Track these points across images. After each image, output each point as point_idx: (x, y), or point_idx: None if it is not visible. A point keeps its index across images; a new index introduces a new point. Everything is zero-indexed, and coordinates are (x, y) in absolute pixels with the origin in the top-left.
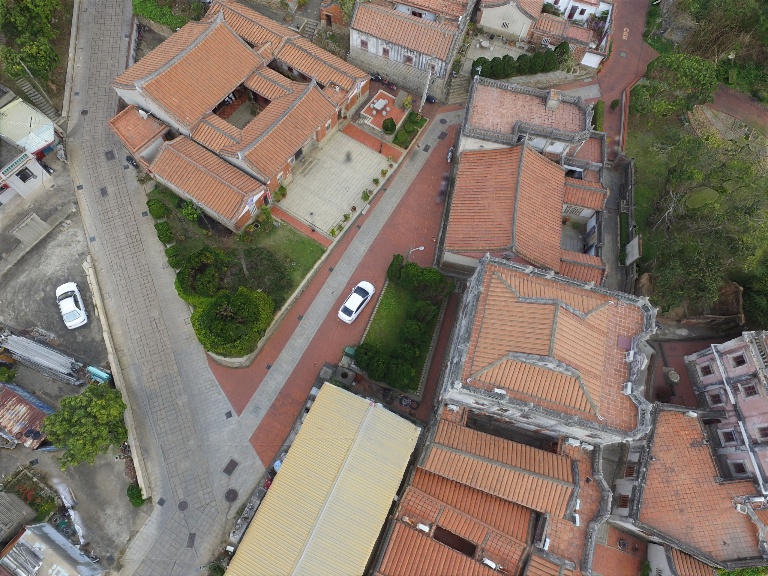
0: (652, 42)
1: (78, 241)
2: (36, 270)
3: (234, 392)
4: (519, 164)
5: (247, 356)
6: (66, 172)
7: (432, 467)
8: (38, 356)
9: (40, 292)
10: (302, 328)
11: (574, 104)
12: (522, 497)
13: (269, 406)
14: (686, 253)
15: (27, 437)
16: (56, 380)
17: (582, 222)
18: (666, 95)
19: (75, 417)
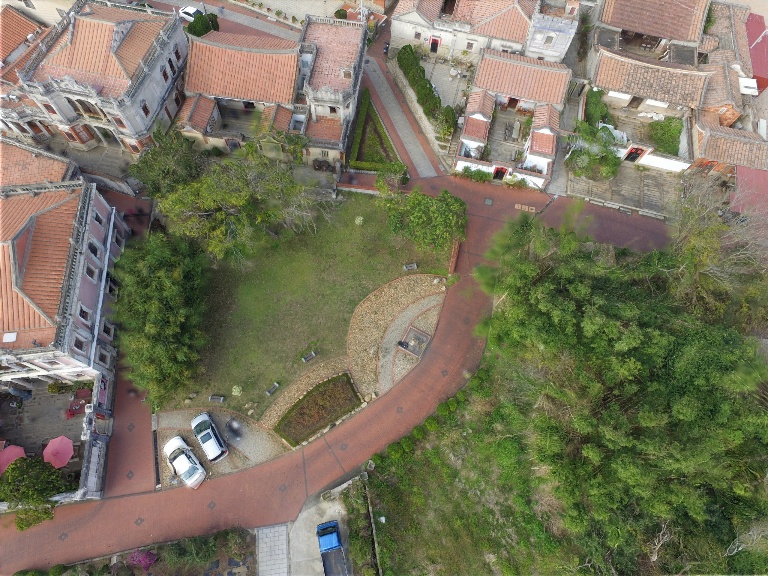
0: (518, 232)
1: None
2: None
3: None
4: None
5: None
6: None
7: None
8: None
9: None
10: (182, 1)
11: None
12: None
13: None
14: None
15: None
16: None
17: None
18: None
19: None
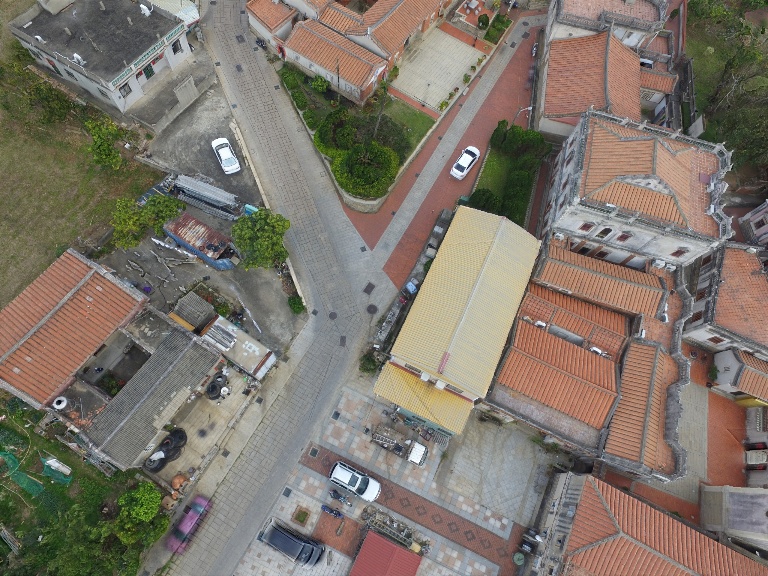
0: None
1: (222, 107)
2: (190, 128)
3: (366, 232)
4: (606, 46)
5: (379, 200)
6: (204, 51)
7: (546, 278)
8: (206, 191)
9: (196, 145)
10: (419, 183)
11: (649, 1)
12: (621, 301)
13: (397, 243)
14: (749, 119)
15: (209, 249)
16: (216, 217)
17: (650, 108)
18: (721, 3)
19: (258, 225)
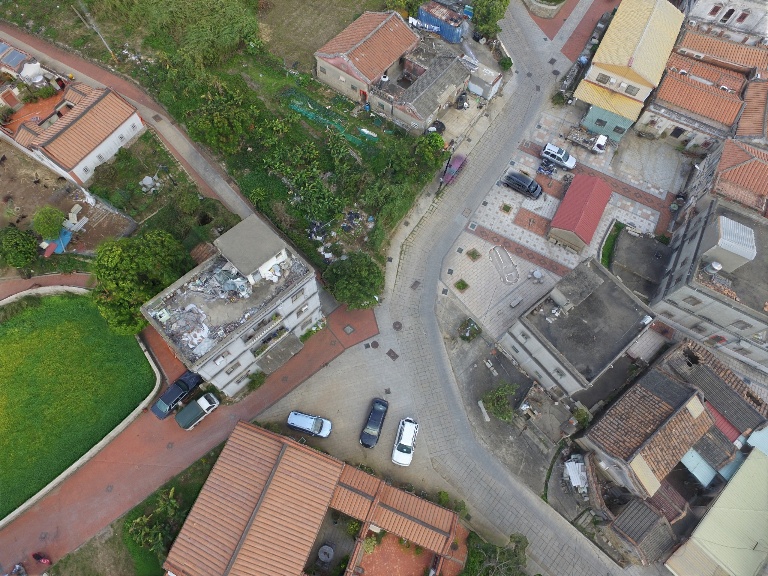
0: None
1: None
2: None
3: (547, 29)
4: None
5: (557, 6)
6: None
7: (686, 45)
8: None
9: None
10: (582, 3)
11: None
12: (740, 60)
13: (569, 37)
14: None
15: (452, 21)
16: None
17: None
18: None
19: None
